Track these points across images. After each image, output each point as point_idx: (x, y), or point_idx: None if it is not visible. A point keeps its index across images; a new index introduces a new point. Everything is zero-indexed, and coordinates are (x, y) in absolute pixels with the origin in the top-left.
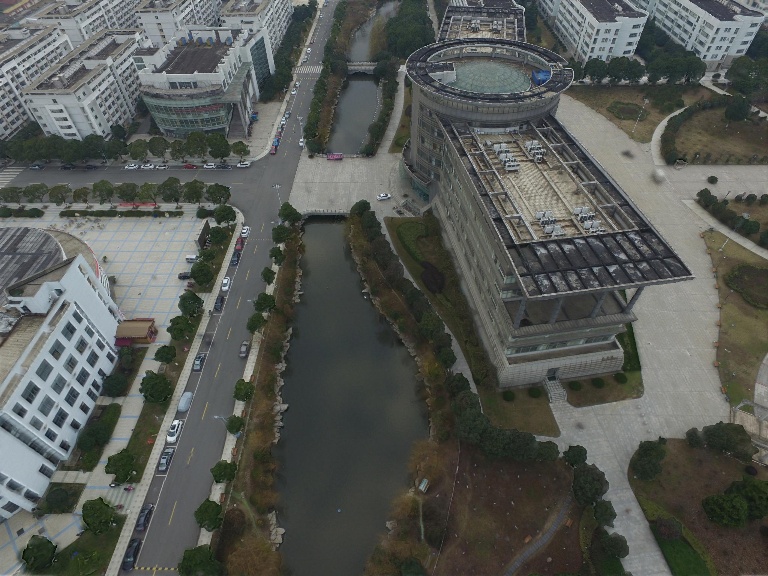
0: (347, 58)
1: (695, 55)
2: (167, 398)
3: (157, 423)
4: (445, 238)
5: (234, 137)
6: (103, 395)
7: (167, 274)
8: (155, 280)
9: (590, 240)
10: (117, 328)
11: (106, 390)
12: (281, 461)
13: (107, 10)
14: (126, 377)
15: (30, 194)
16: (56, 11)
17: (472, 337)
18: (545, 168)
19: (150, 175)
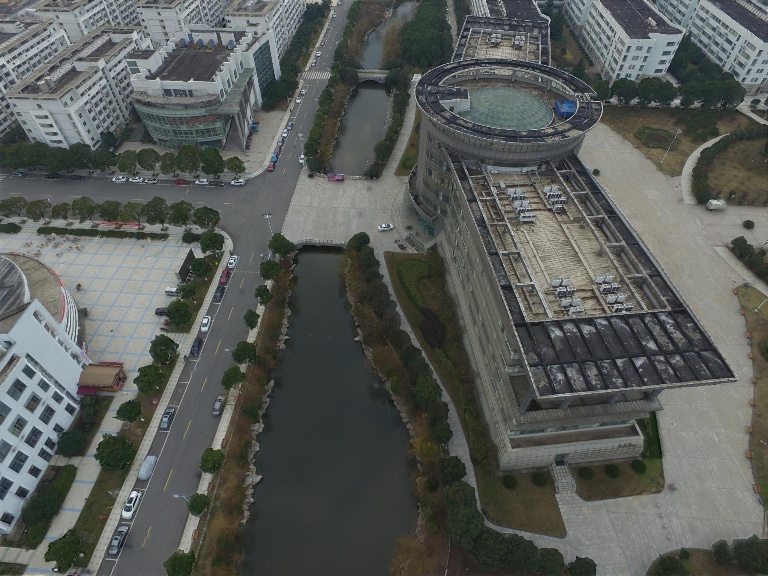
0: (358, 64)
1: (733, 77)
2: (126, 465)
3: (114, 492)
4: (449, 281)
5: (231, 149)
6: (58, 453)
7: (144, 308)
8: (130, 315)
9: (614, 321)
10: (81, 374)
11: (60, 450)
12: (250, 540)
13: (109, 3)
14: (86, 432)
15: (6, 209)
16: (55, 3)
17: (472, 407)
18: (565, 220)
19: (138, 189)
